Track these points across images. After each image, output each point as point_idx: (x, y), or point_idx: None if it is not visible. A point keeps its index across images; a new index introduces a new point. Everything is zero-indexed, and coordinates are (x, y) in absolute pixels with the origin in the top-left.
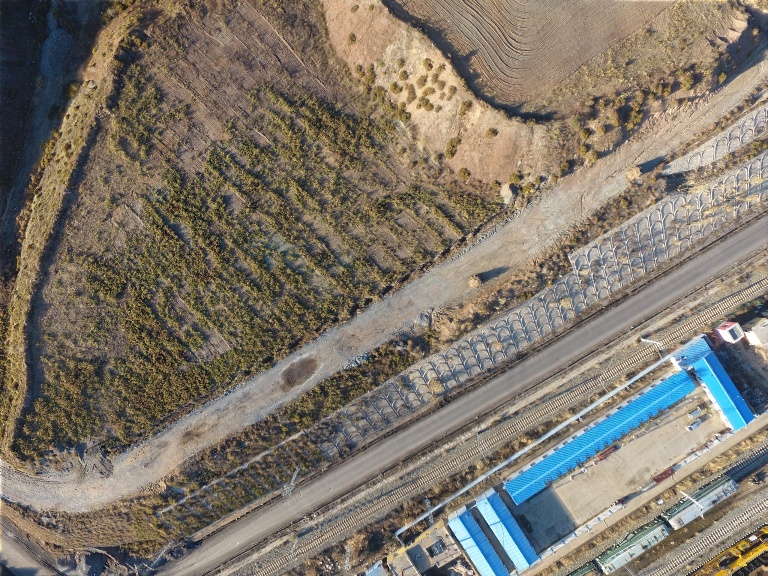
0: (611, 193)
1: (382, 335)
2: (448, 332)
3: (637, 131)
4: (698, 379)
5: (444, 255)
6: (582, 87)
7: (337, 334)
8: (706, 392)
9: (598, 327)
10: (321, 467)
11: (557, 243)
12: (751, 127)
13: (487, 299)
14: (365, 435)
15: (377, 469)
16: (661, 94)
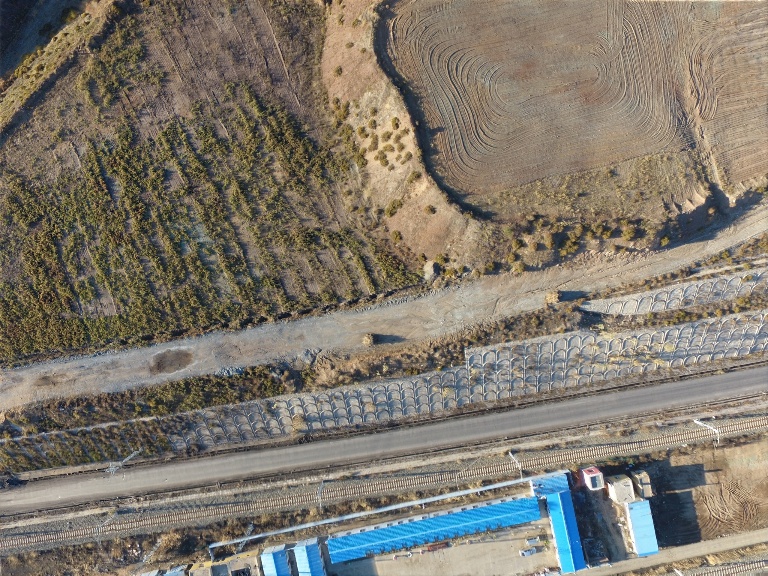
0: (526, 307)
1: (263, 356)
2: (326, 377)
3: (570, 259)
4: (548, 511)
5: (351, 304)
6: (529, 200)
7: (221, 339)
8: (551, 526)
9: (475, 425)
10: (165, 456)
11: (459, 334)
12: (679, 296)
13: (373, 361)
14: (218, 442)
15: (217, 478)
16: (600, 235)
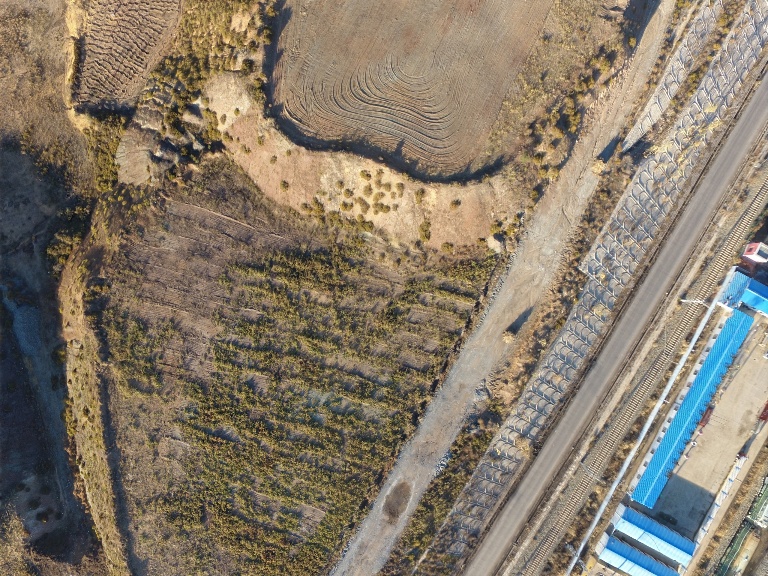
0: (587, 194)
1: (452, 428)
2: (509, 394)
3: (581, 128)
4: (752, 308)
5: (468, 327)
6: (513, 121)
7: (412, 449)
8: (765, 316)
9: (637, 310)
10: (459, 566)
11: (563, 263)
12: (680, 67)
13: (528, 347)
14: (482, 518)
15: (509, 541)
16: (587, 89)
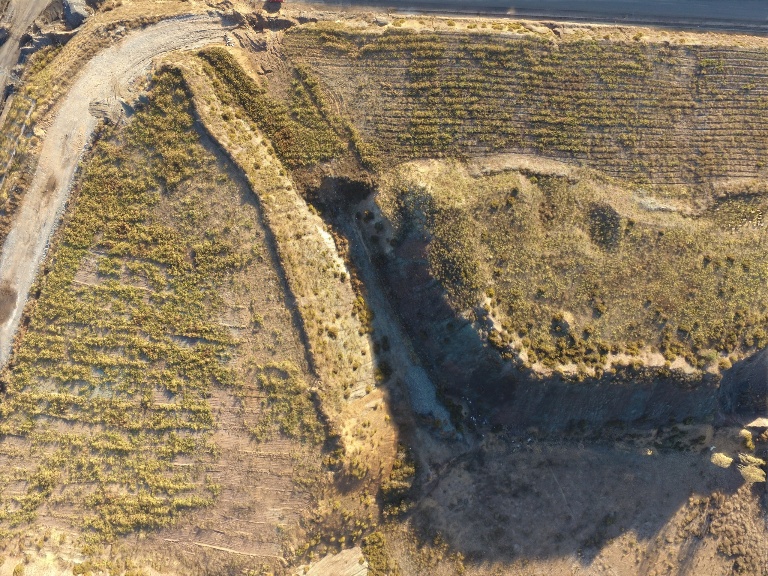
0: None
1: None
2: None
3: None
4: None
5: None
6: None
7: None
8: None
9: None
10: None
11: None
12: None
13: None
14: None
15: None
16: None
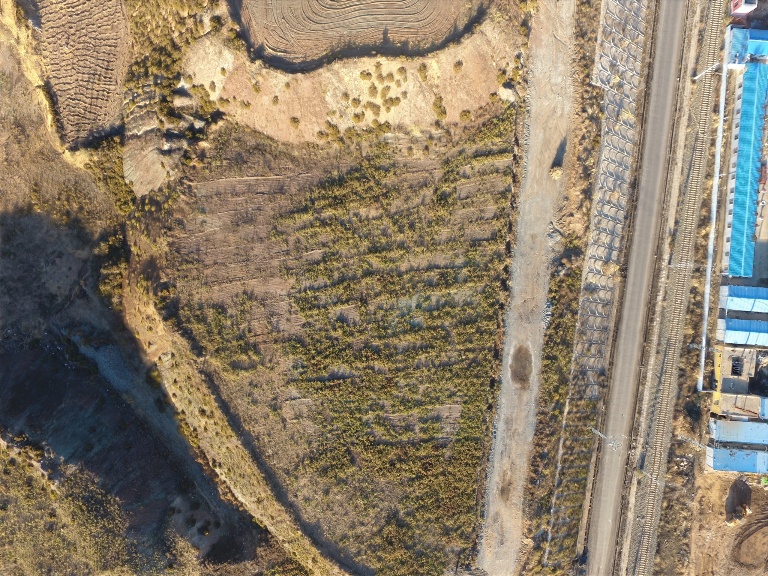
0: (570, 11)
1: (542, 278)
2: (579, 225)
3: None
4: (761, 58)
5: (515, 181)
6: None
7: (514, 313)
8: None
9: (657, 106)
10: (600, 409)
11: (576, 84)
12: None
13: (578, 173)
14: (602, 355)
15: (635, 366)
16: None
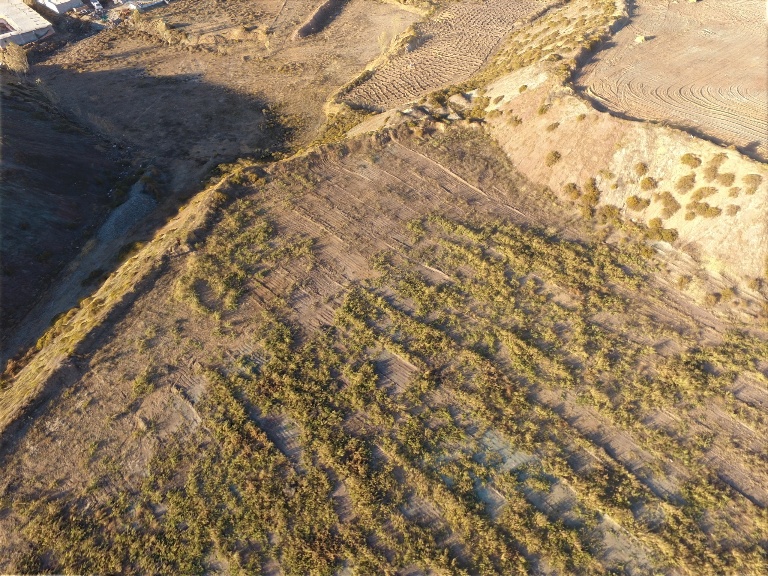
0: None
1: None
2: None
3: None
4: None
5: None
6: None
7: None
8: None
9: None
10: None
11: None
12: None
13: None
14: None
15: None
16: None
